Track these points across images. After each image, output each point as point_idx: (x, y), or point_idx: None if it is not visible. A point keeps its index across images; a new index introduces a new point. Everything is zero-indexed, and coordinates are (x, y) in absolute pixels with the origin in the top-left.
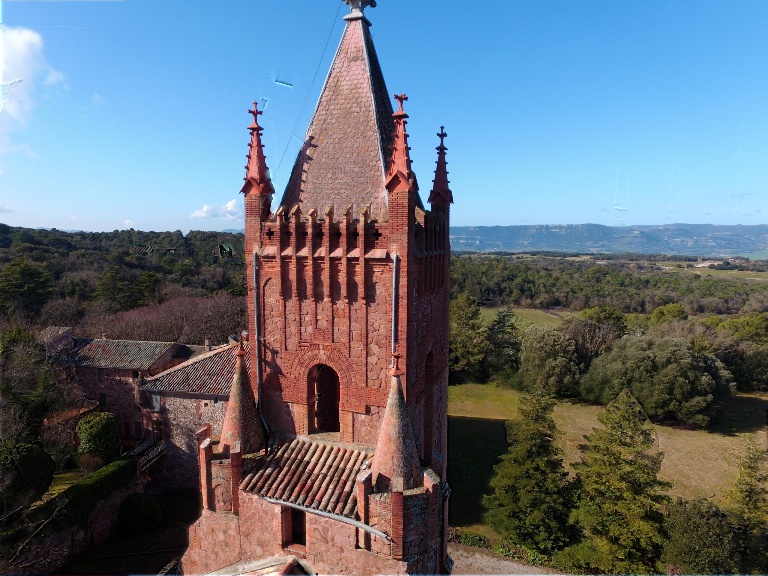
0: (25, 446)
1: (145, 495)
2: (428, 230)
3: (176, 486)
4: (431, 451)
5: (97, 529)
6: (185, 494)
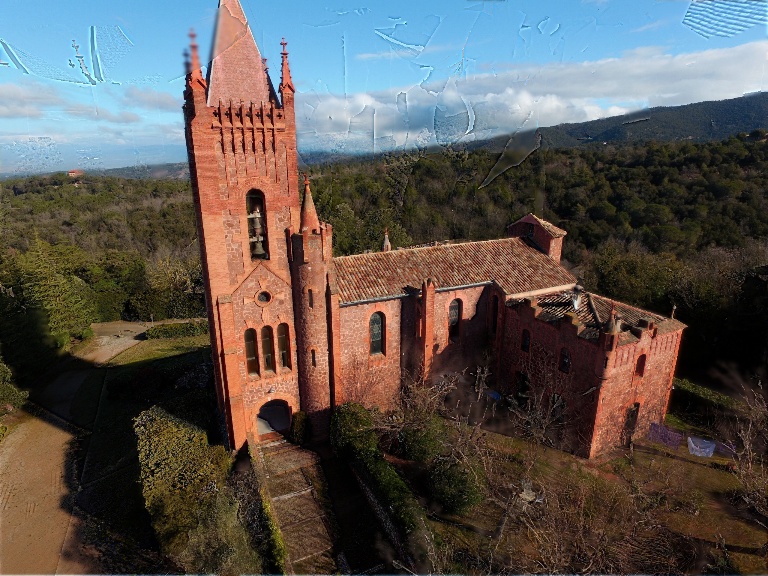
0: None
1: None
2: None
3: None
4: None
5: None
6: None
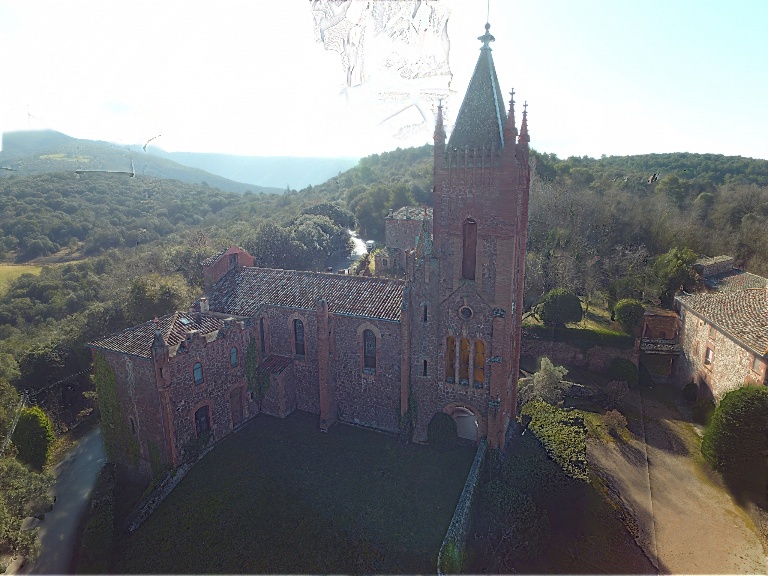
0: (568, 292)
1: (630, 363)
2: (457, 155)
3: (679, 385)
4: (475, 275)
5: (593, 362)
6: (674, 391)
